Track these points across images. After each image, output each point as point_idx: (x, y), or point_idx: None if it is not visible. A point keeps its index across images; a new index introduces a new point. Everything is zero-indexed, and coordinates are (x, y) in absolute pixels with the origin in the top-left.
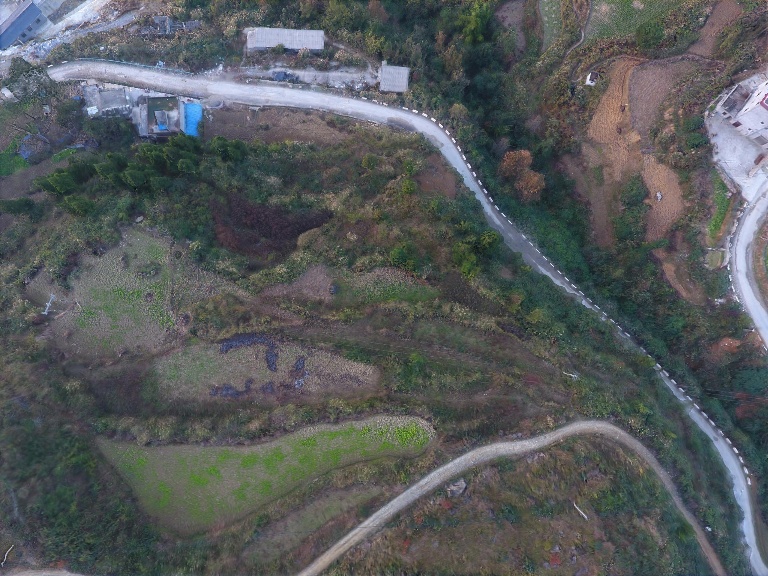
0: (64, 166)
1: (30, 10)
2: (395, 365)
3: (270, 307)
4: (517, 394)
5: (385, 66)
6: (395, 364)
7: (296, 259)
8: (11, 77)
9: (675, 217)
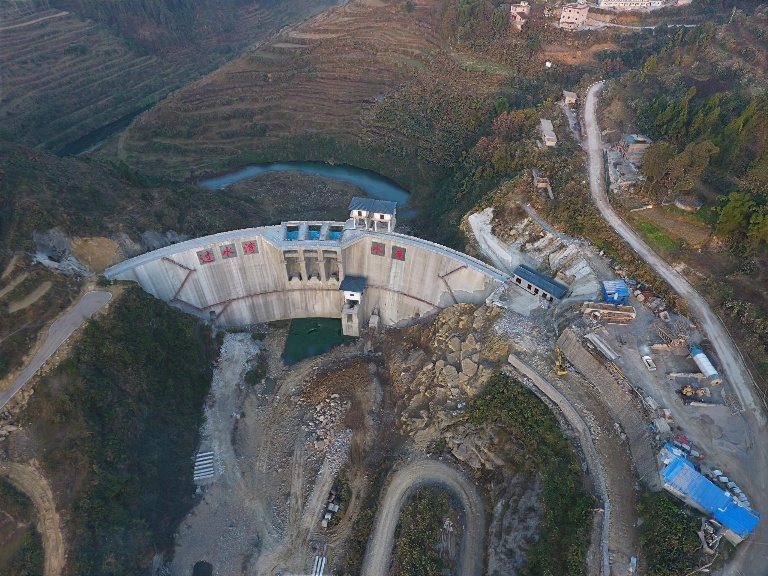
0: (697, 183)
1: (525, 268)
2: (766, 33)
3: (762, 62)
4: (752, 21)
5: (564, 95)
6: (765, 34)
7: (724, 66)
8: (666, 149)
9: (616, 45)
